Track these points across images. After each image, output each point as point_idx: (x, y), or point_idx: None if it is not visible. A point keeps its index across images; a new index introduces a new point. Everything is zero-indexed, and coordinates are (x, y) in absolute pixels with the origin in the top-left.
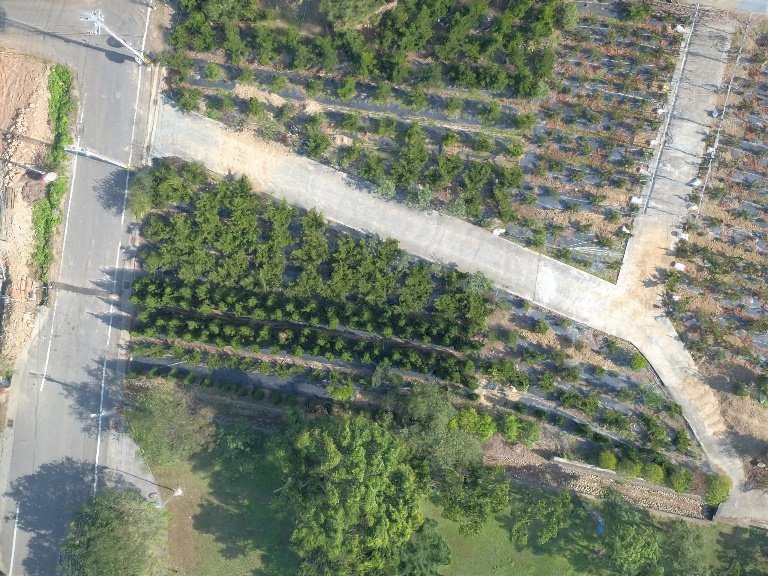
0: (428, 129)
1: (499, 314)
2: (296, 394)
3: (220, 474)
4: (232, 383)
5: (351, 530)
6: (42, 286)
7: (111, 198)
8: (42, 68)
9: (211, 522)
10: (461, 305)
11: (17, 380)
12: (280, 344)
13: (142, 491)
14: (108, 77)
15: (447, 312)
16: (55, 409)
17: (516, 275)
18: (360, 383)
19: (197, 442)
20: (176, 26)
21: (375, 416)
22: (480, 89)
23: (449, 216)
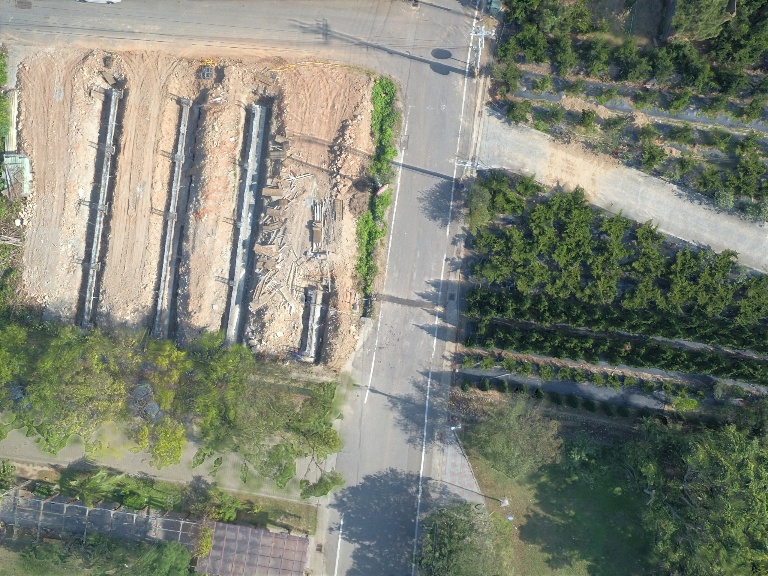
0: (758, 141)
1: None
2: (625, 405)
3: (546, 485)
4: (562, 394)
5: None
6: (363, 298)
7: (436, 210)
8: (365, 80)
9: (537, 533)
10: None
11: (341, 392)
12: (621, 356)
13: (468, 502)
14: (433, 89)
15: None
16: (379, 420)
17: None
18: (696, 394)
19: (549, 454)
20: (500, 37)
21: (720, 427)
22: None
23: None
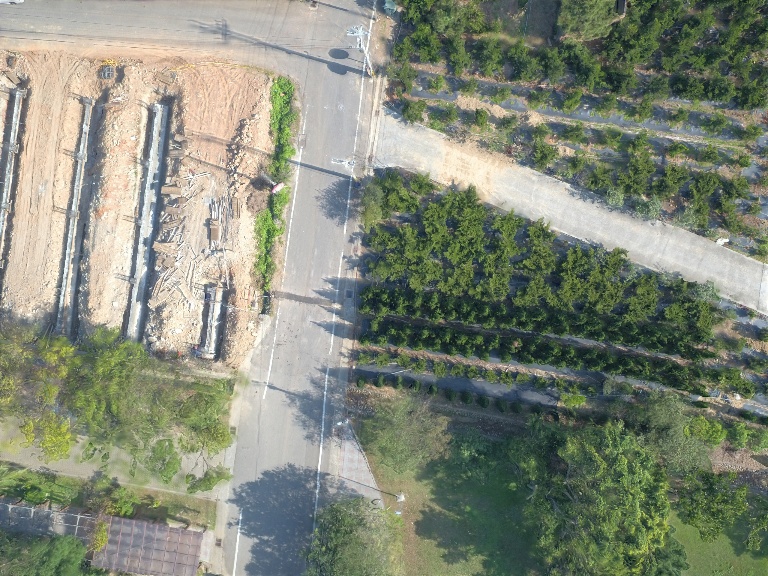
0: (651, 140)
1: (722, 323)
2: (519, 401)
3: (442, 480)
4: (456, 391)
5: (610, 537)
6: (263, 295)
7: (334, 208)
8: (264, 79)
9: (433, 528)
10: (689, 314)
11: (239, 388)
12: (511, 353)
13: (365, 497)
14: (331, 88)
15: (677, 321)
16: (278, 416)
17: (740, 284)
18: (587, 391)
19: (437, 450)
20: (397, 38)
21: (608, 424)
22: (703, 100)
23: (672, 226)
